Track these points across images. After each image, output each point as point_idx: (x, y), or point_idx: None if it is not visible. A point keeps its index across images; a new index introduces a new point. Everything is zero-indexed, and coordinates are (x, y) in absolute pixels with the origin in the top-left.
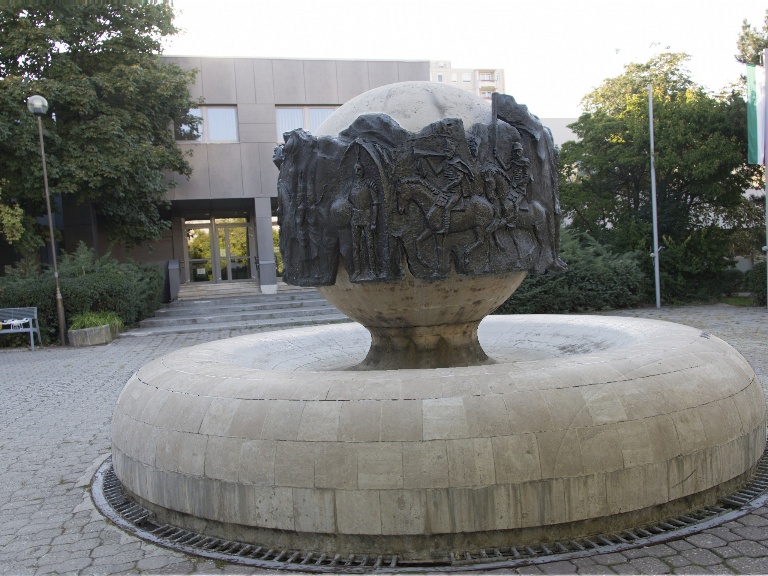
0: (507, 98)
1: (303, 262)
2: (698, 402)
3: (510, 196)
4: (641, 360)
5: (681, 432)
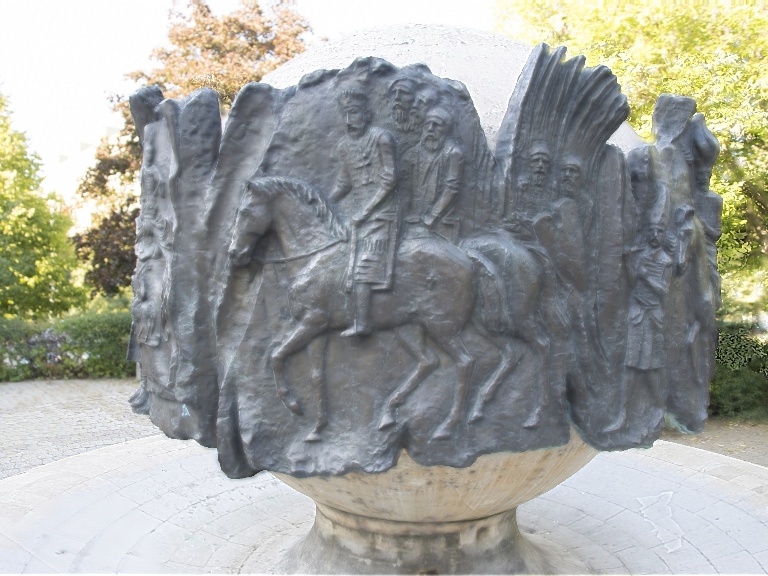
0: None
1: (708, 380)
2: None
3: None
4: None
5: None
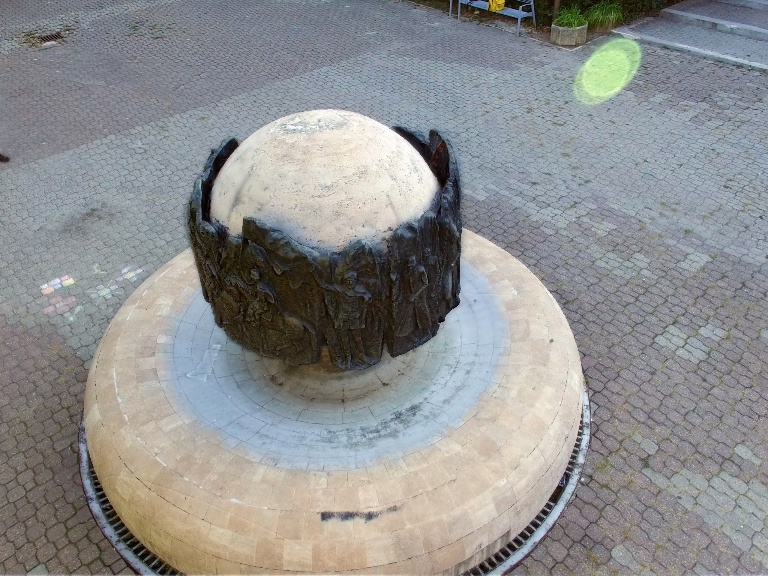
0: (254, 226)
1: None
2: (177, 536)
3: (252, 305)
4: (181, 486)
5: (153, 535)
